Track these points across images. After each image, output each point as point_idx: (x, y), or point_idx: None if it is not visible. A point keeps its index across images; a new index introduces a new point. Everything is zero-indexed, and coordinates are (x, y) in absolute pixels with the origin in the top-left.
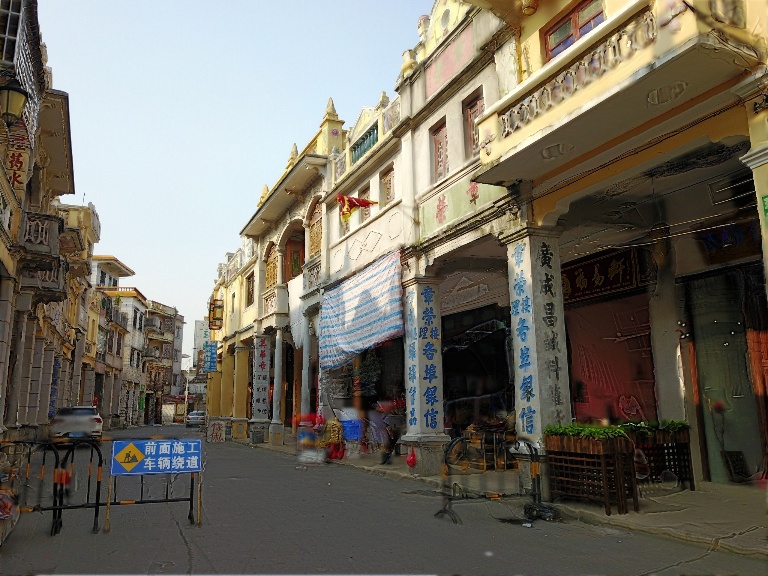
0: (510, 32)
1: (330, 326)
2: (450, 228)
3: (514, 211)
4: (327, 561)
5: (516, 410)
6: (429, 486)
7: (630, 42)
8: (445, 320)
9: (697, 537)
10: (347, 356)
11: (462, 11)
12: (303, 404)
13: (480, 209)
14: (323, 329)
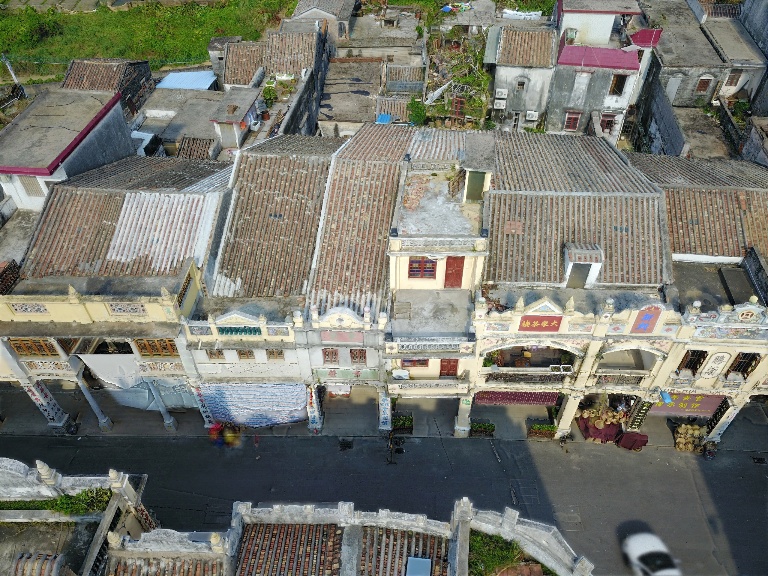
0: None
1: (221, 398)
2: None
3: None
4: (421, 504)
5: (380, 421)
6: (333, 438)
7: (436, 365)
8: None
9: (437, 437)
10: (256, 411)
11: (354, 325)
12: (166, 415)
13: (363, 381)
14: None
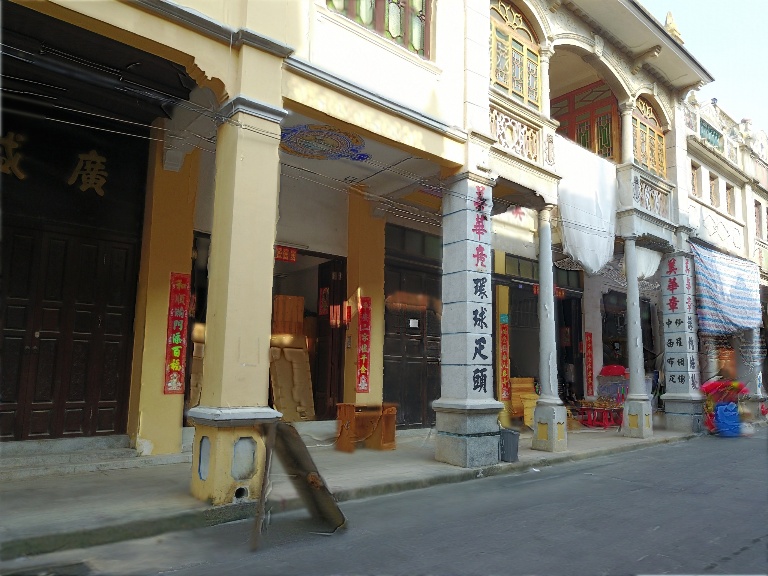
0: None
1: None
2: None
3: None
4: None
5: None
6: None
7: None
8: (613, 294)
9: None
10: None
11: (767, 159)
12: None
13: None
14: (702, 286)
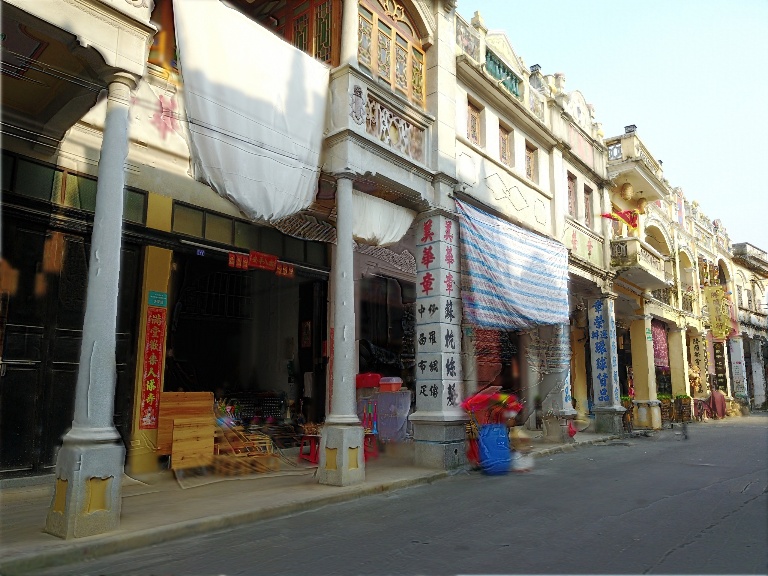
0: (609, 187)
1: None
2: (589, 264)
3: (610, 282)
4: None
5: (613, 389)
6: (592, 445)
7: None
8: None
9: None
10: None
11: None
12: None
13: None
14: (470, 260)
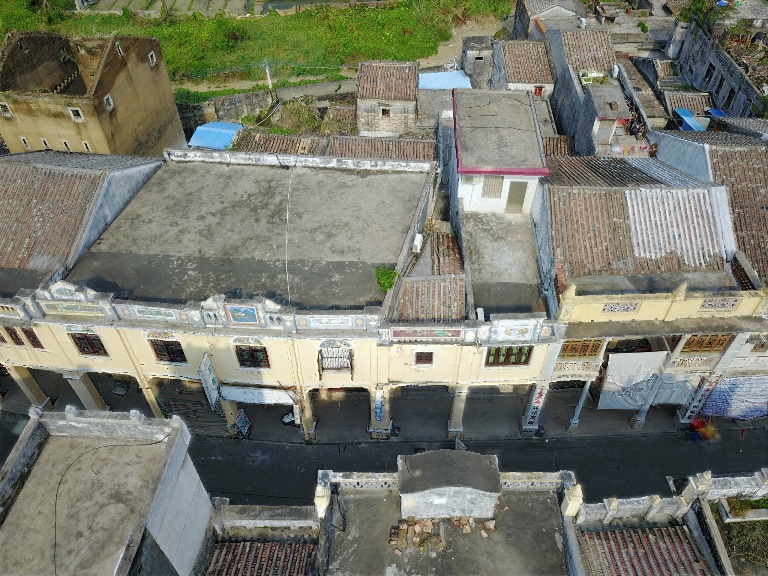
0: None
1: None
2: None
3: None
4: None
5: None
6: None
7: None
8: None
9: None
10: None
11: None
12: None
13: None
14: (718, 392)
